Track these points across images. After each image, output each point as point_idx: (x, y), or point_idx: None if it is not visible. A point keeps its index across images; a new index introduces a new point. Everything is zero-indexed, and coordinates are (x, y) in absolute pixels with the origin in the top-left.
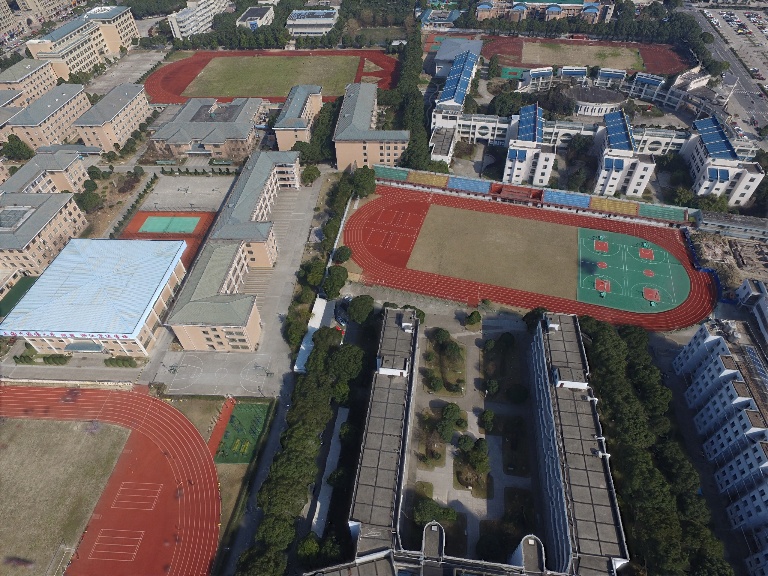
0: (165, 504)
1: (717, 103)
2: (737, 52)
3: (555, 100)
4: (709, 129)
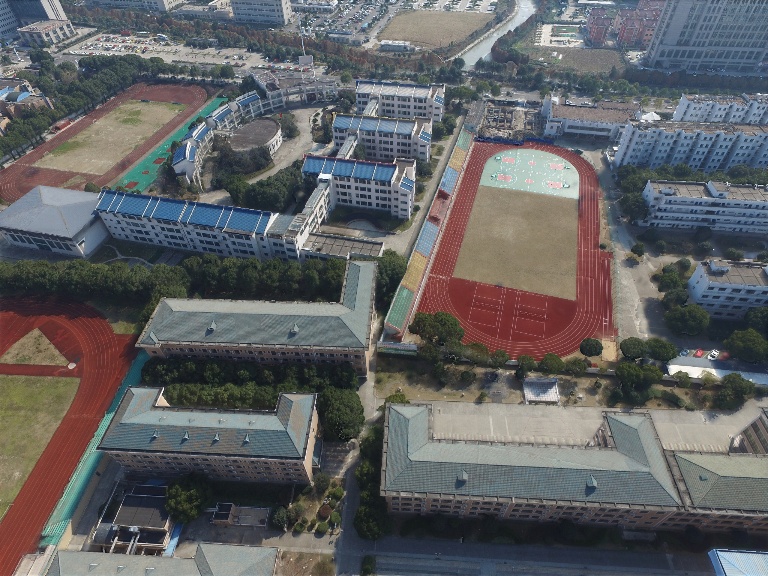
0: None
1: (309, 82)
2: None
3: (251, 158)
4: (375, 88)
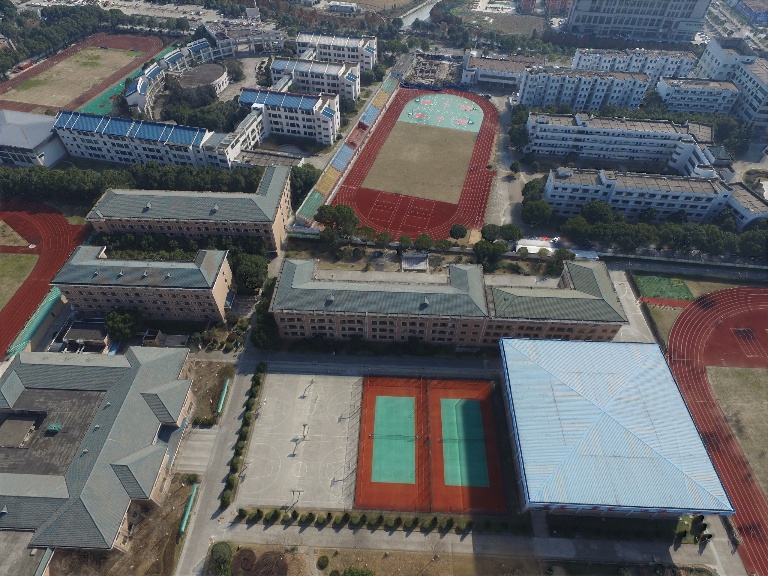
0: (742, 322)
1: (256, 33)
2: None
3: (198, 94)
4: (314, 38)
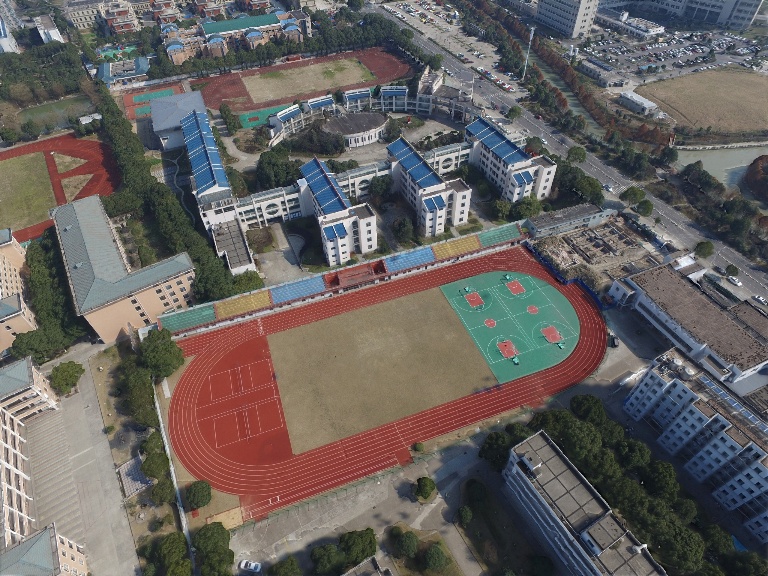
0: None
1: (464, 99)
2: (435, 41)
3: (321, 141)
4: (484, 132)
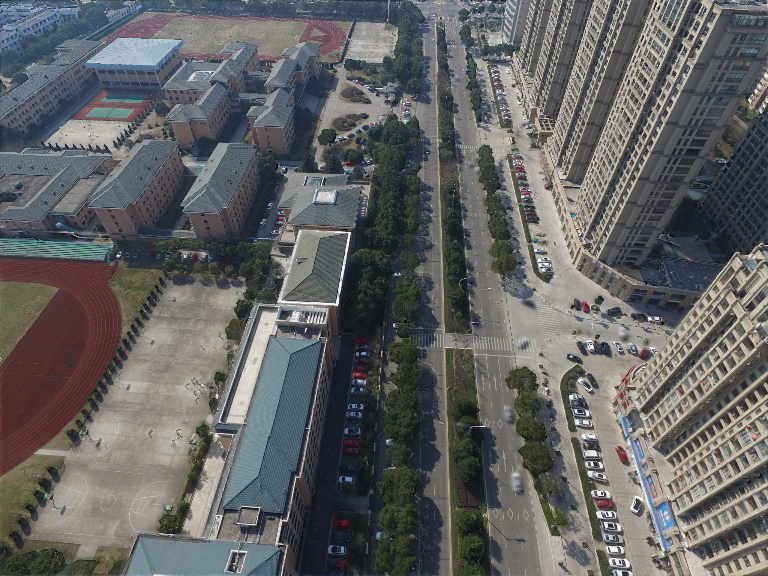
0: None
1: None
2: None
3: None
4: None
